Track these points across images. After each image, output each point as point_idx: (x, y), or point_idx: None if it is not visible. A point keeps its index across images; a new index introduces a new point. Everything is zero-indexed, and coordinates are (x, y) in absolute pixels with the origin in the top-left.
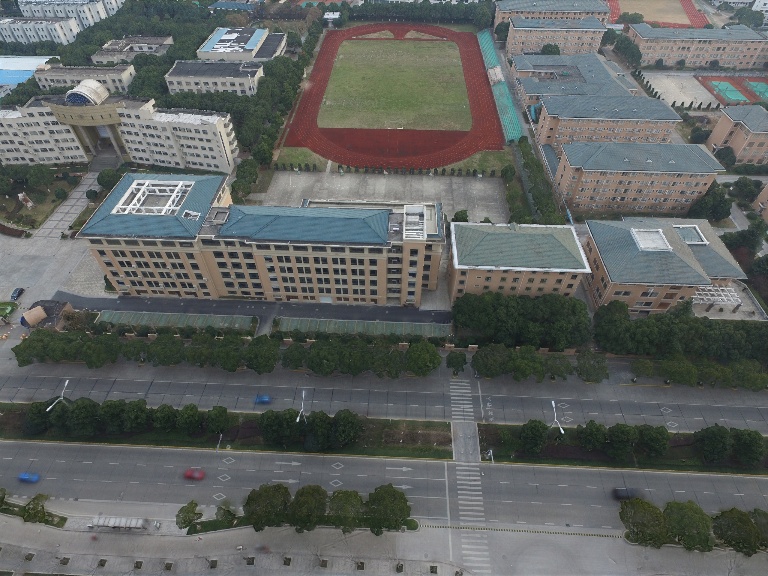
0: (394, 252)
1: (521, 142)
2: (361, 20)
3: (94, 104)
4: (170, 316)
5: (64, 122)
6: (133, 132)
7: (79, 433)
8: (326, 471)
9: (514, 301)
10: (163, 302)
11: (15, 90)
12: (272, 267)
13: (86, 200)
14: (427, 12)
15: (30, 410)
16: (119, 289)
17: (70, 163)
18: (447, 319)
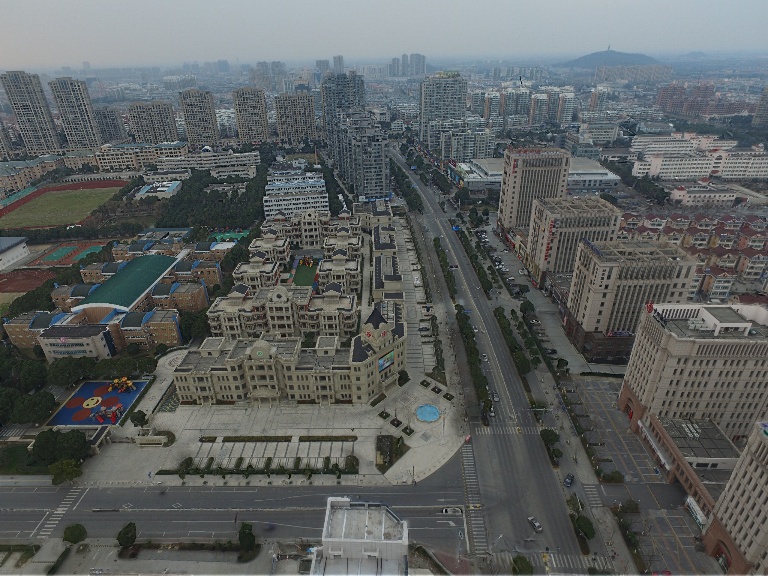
0: None
1: (35, 183)
2: None
3: None
4: None
5: None
6: None
7: None
8: None
9: None
10: None
11: None
12: None
13: None
14: None
15: None
16: None
17: None
18: None
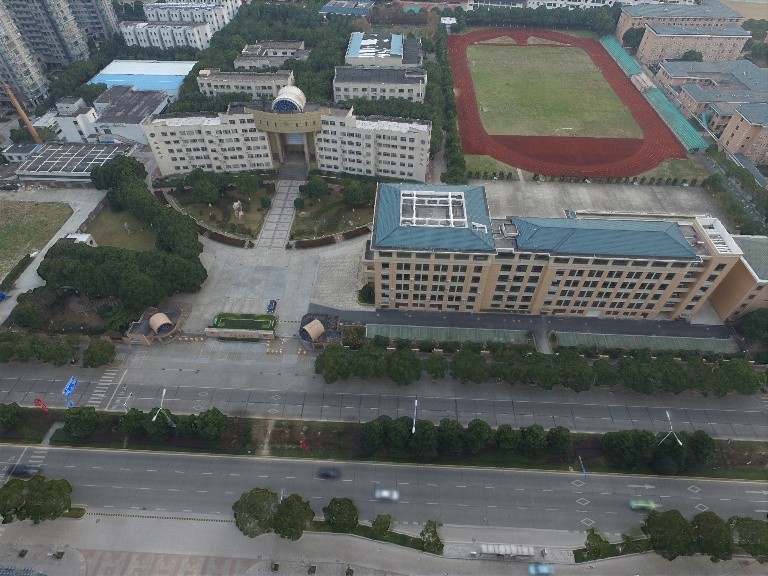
0: (695, 266)
1: (712, 151)
2: (474, 25)
3: (300, 111)
4: (439, 330)
5: (264, 129)
6: (331, 140)
7: (425, 454)
8: (685, 495)
9: None
10: (424, 315)
11: (184, 96)
12: (558, 281)
13: (291, 209)
14: (545, 18)
15: (372, 430)
16: (380, 302)
17: (256, 170)
18: (726, 334)
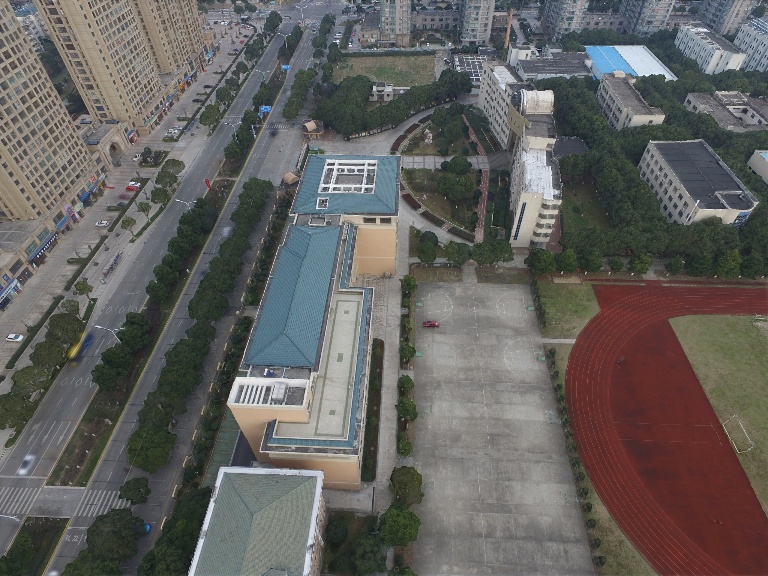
0: None
1: None
2: None
3: (521, 110)
4: None
5: None
6: None
7: None
8: None
9: (168, 572)
10: None
11: (572, 77)
12: None
13: None
14: None
15: None
16: None
17: (498, 143)
18: None
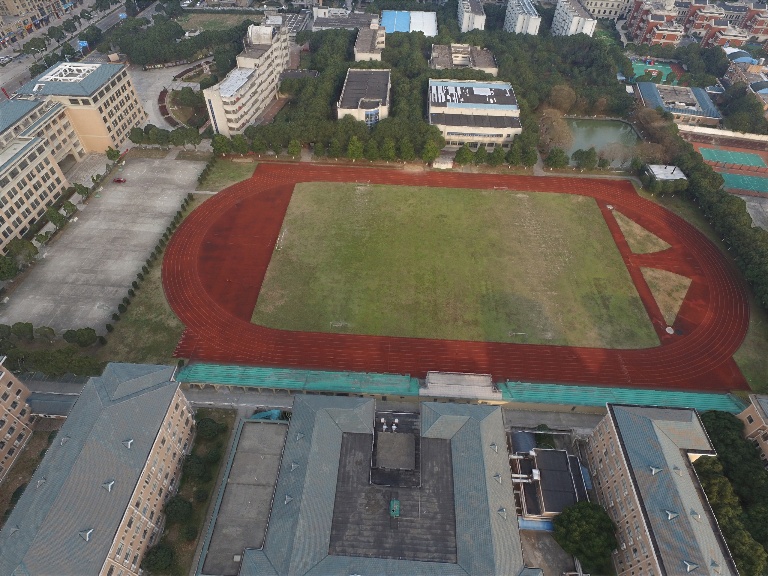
0: None
1: None
2: (704, 214)
3: (249, 40)
4: None
5: None
6: None
7: None
8: None
9: None
10: None
11: None
12: None
13: None
14: (763, 288)
15: None
16: None
17: None
18: None
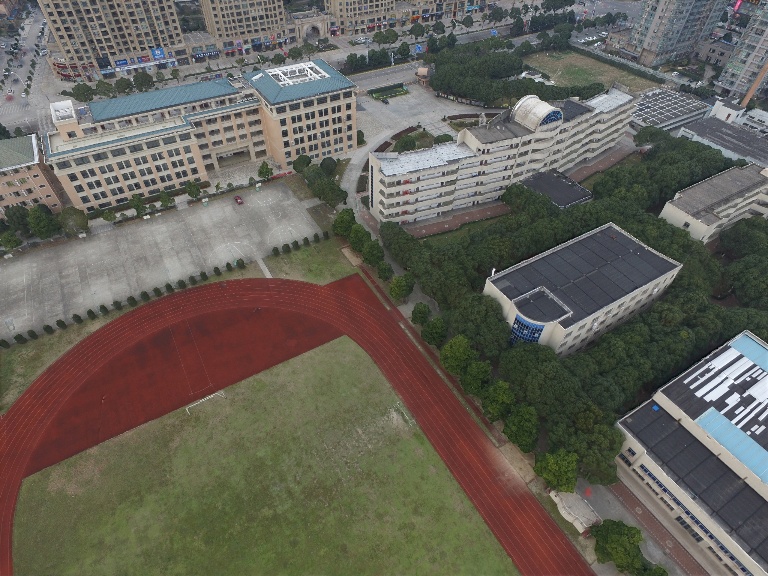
0: None
1: None
2: None
3: None
4: None
5: None
6: None
7: None
8: None
9: None
10: None
11: None
12: None
13: None
14: None
15: None
16: None
17: None
18: None
